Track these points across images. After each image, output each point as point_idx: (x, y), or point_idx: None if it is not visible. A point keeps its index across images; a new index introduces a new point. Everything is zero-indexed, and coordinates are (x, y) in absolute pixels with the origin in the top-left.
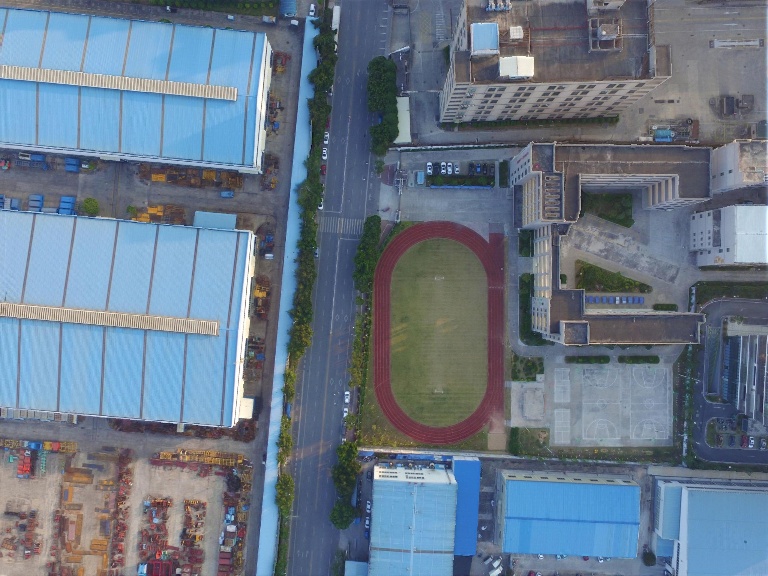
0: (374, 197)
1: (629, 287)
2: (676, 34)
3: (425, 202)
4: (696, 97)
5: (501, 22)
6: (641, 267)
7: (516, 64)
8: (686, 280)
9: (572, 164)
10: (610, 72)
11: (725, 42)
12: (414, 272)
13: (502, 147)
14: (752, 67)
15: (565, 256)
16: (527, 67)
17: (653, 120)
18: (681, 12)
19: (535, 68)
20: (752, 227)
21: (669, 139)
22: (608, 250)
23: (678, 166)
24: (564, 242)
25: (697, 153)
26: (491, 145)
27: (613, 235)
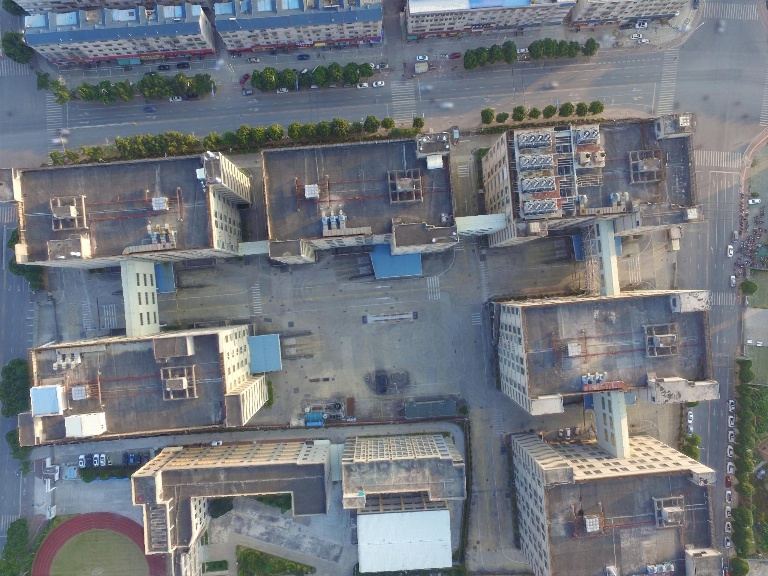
0: (29, 492)
1: (291, 570)
2: (328, 311)
3: (81, 494)
4: (351, 374)
5: (73, 374)
6: (304, 548)
7: (80, 425)
8: (350, 559)
9: (184, 487)
10: (189, 418)
11: (378, 317)
12: (73, 566)
13: (155, 436)
14: (407, 340)
15: (226, 541)
16: (93, 427)
17: (308, 400)
18: (332, 289)
19: (111, 419)
20: (374, 537)
21: (320, 422)
22: (269, 533)
23: (293, 482)
24: (224, 528)
25: (312, 468)
26: (143, 435)
27: (273, 518)
